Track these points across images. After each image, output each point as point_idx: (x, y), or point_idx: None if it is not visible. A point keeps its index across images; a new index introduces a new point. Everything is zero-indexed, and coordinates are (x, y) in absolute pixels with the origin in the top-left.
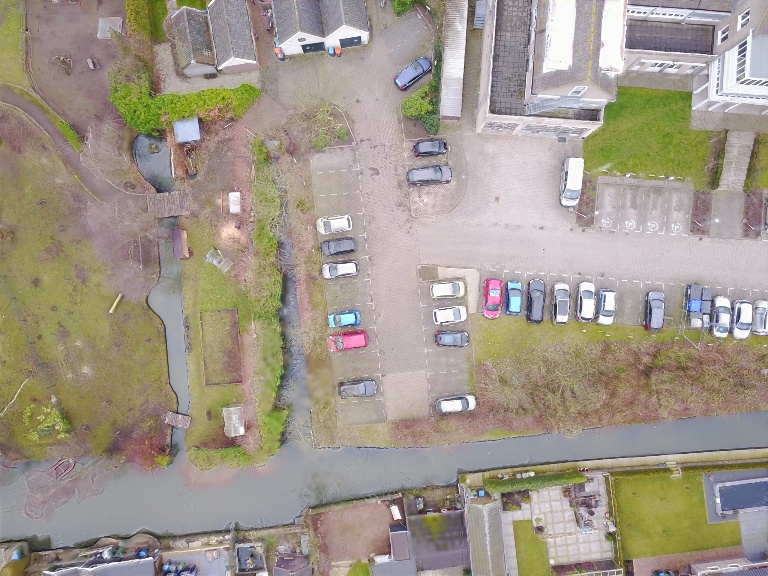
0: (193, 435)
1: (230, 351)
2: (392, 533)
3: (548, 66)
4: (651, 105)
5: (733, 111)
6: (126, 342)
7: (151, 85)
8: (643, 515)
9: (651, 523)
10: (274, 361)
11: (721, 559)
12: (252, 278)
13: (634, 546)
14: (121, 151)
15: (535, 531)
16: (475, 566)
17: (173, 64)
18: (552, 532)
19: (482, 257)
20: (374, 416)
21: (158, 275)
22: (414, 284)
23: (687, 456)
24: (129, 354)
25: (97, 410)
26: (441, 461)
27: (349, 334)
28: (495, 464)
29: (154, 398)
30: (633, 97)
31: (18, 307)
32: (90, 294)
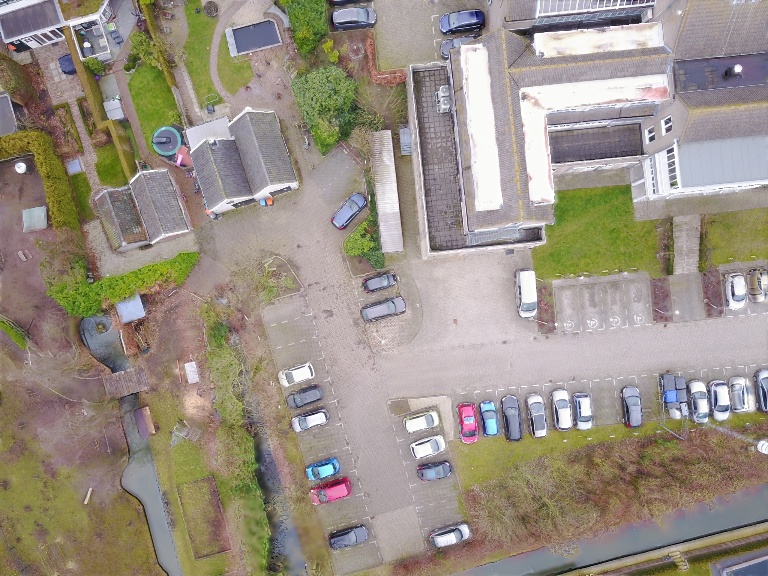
0: None
1: (213, 520)
2: None
3: (479, 209)
4: (592, 204)
5: (674, 196)
6: (107, 530)
7: (87, 266)
8: None
9: None
10: (259, 529)
11: None
12: (222, 451)
13: None
14: (68, 339)
15: None
16: None
17: (106, 241)
18: None
19: (450, 382)
20: (370, 560)
21: (127, 456)
22: (387, 420)
23: (689, 544)
24: (112, 541)
25: None
26: None
27: (330, 485)
28: None
29: None
30: (573, 199)
31: None
32: (62, 488)
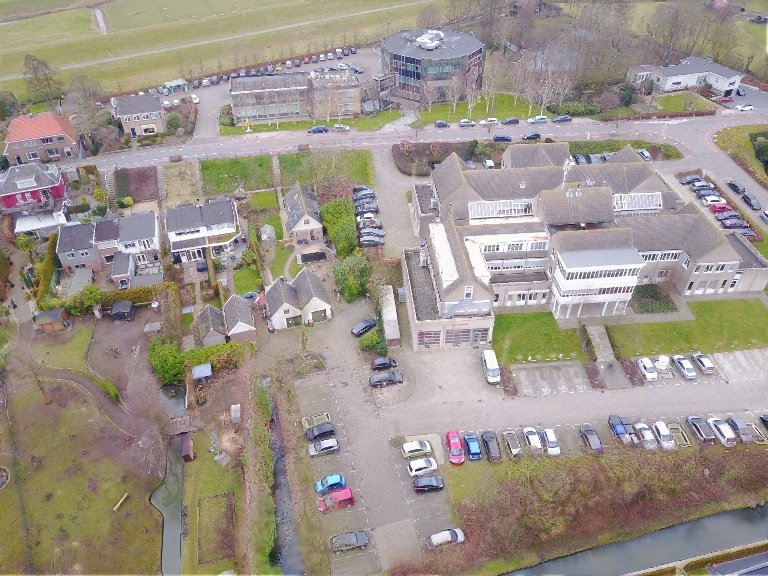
0: None
1: (225, 530)
2: None
3: (444, 279)
4: (528, 321)
5: (583, 317)
6: (124, 536)
7: None
8: None
9: None
10: (268, 516)
11: None
12: (249, 449)
13: None
14: None
15: None
16: None
17: (194, 344)
18: None
19: (439, 425)
20: (369, 568)
21: (164, 476)
22: (388, 452)
23: (686, 562)
24: (125, 546)
25: None
26: None
27: (336, 491)
28: None
29: None
30: (514, 318)
31: (25, 520)
32: (98, 499)
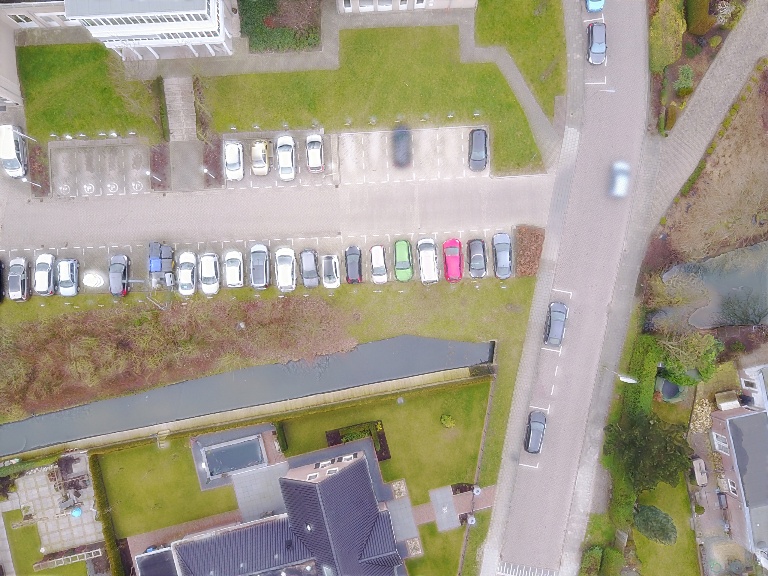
0: None
1: None
2: None
3: None
4: (81, 61)
5: (166, 57)
6: None
7: None
8: (133, 490)
9: (142, 497)
10: None
11: (216, 526)
12: None
13: (127, 523)
14: None
15: None
16: None
17: None
18: None
19: None
20: None
21: None
22: None
23: (181, 423)
24: None
25: None
26: None
27: None
28: None
29: None
30: (60, 55)
31: None
32: None
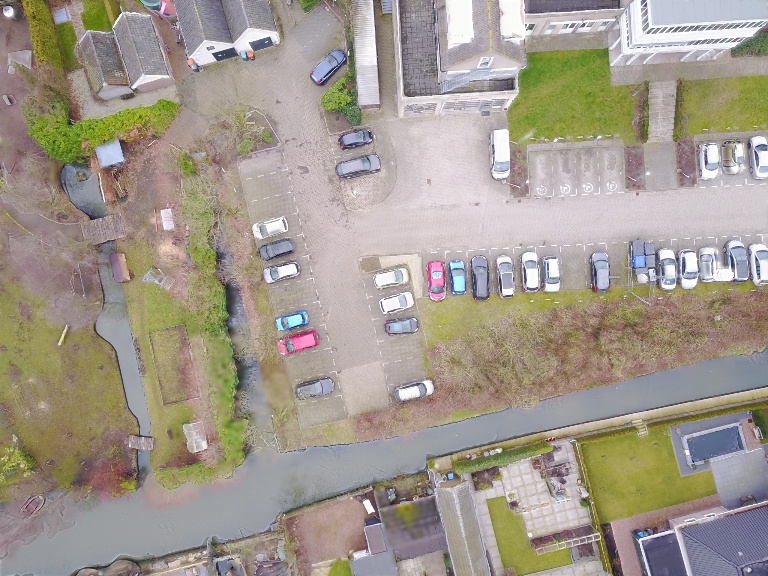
0: (158, 456)
1: (184, 368)
2: (366, 527)
3: (450, 41)
4: (569, 67)
5: (651, 62)
6: (79, 372)
7: (70, 113)
8: (615, 477)
9: (624, 484)
10: (226, 372)
11: (698, 510)
12: (192, 292)
13: (610, 509)
14: (48, 183)
15: (510, 507)
16: (452, 549)
17: (89, 89)
18: (527, 505)
19: (422, 241)
20: (335, 413)
21: (102, 301)
22: (358, 277)
23: (652, 412)
24: (84, 384)
25: (59, 443)
26: (411, 449)
27: (298, 335)
28: (465, 445)
29: (114, 424)
30: (550, 61)
31: None
32: (37, 329)
